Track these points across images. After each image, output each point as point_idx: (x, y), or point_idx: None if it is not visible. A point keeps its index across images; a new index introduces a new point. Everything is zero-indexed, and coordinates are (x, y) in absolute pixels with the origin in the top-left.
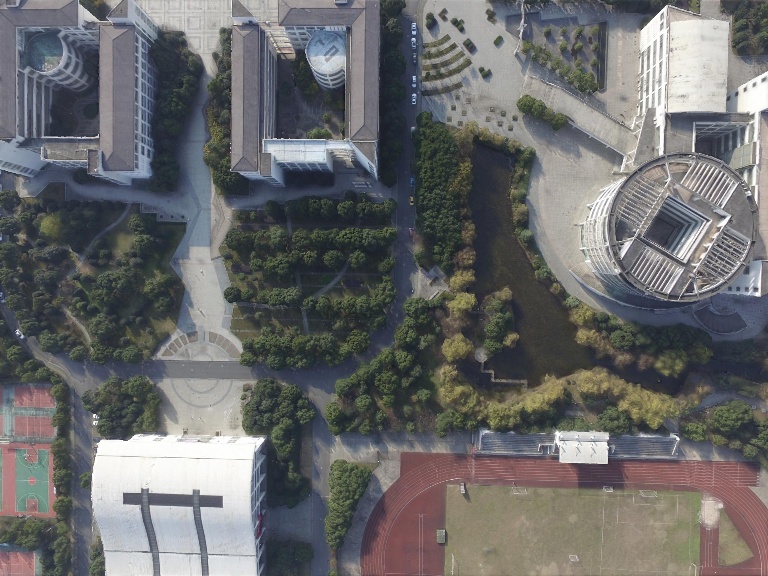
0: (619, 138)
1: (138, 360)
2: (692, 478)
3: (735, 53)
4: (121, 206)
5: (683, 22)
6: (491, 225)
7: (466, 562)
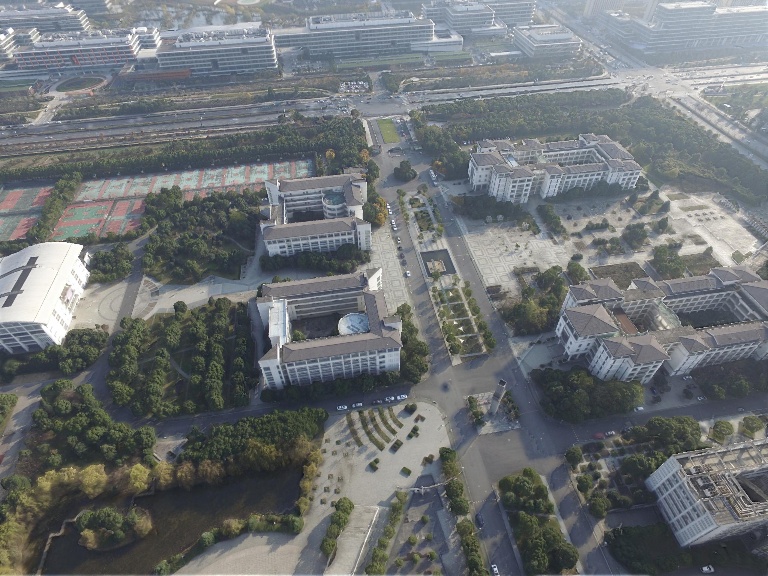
0: None
1: (142, 266)
2: None
3: None
4: (252, 247)
5: None
6: (224, 502)
7: None
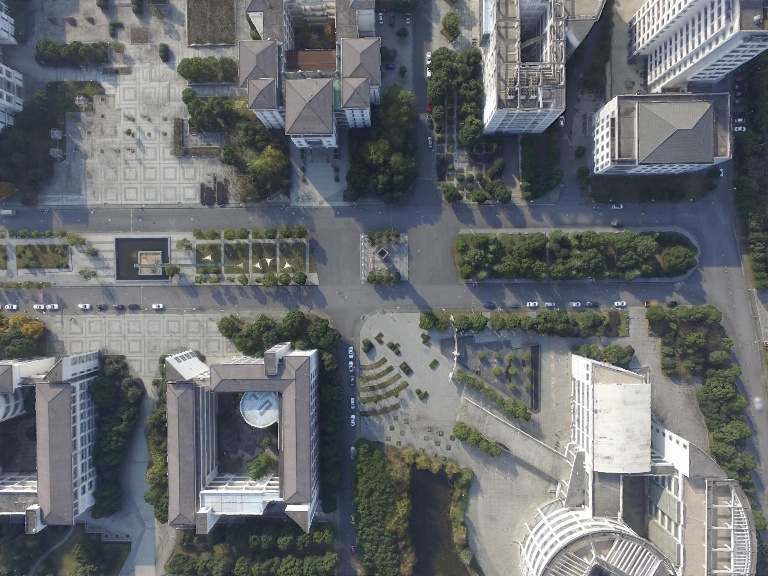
0: (553, 465)
1: None
2: None
3: (665, 374)
4: (66, 528)
5: (606, 386)
6: (432, 540)
7: None
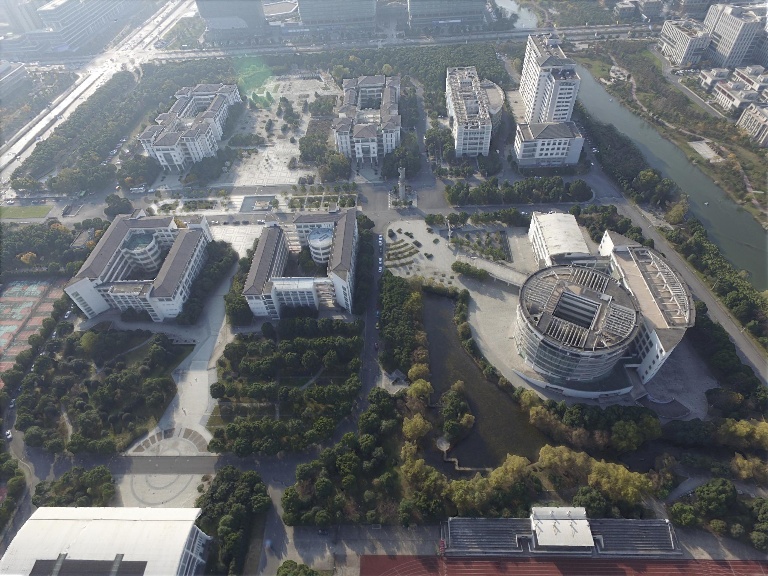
0: None
1: (110, 450)
2: None
3: (595, 242)
4: (149, 334)
5: (544, 215)
6: (442, 341)
7: None
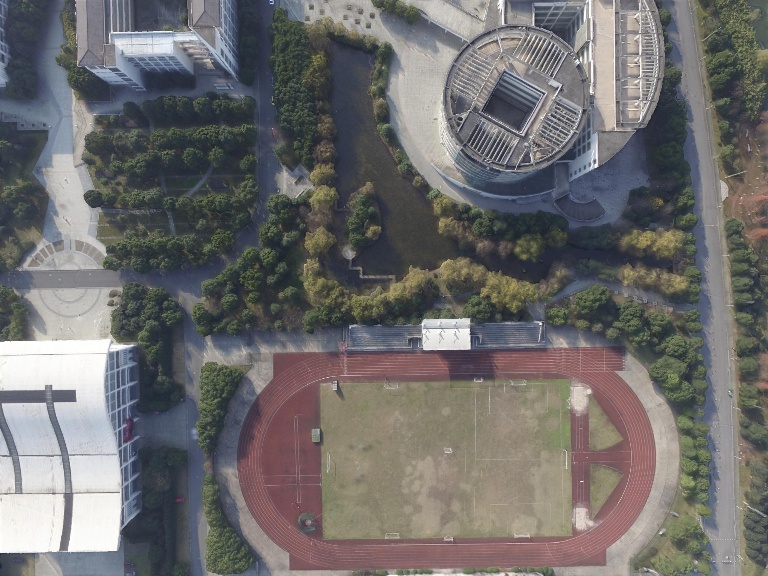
0: (471, 29)
1: (1, 269)
2: (560, 365)
3: None
4: None
5: None
6: (354, 123)
7: (342, 460)
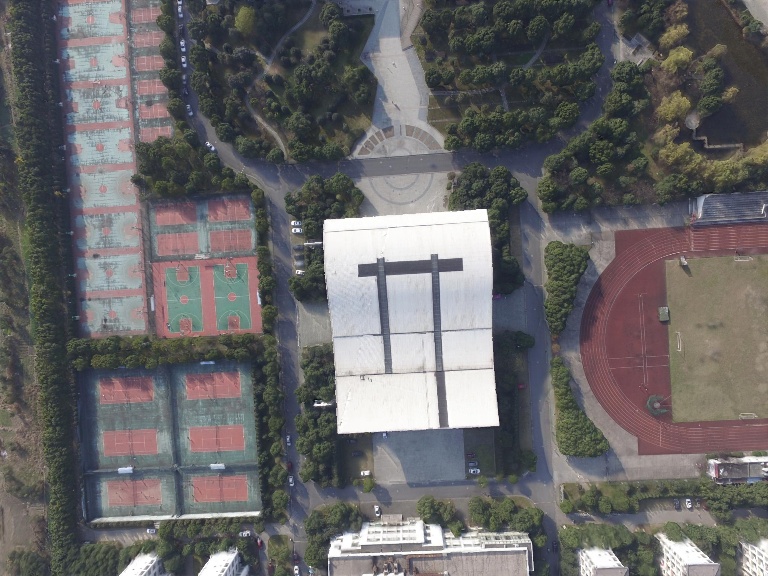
0: None
1: (339, 156)
2: None
3: None
4: (307, 2)
5: None
6: None
7: (691, 339)
